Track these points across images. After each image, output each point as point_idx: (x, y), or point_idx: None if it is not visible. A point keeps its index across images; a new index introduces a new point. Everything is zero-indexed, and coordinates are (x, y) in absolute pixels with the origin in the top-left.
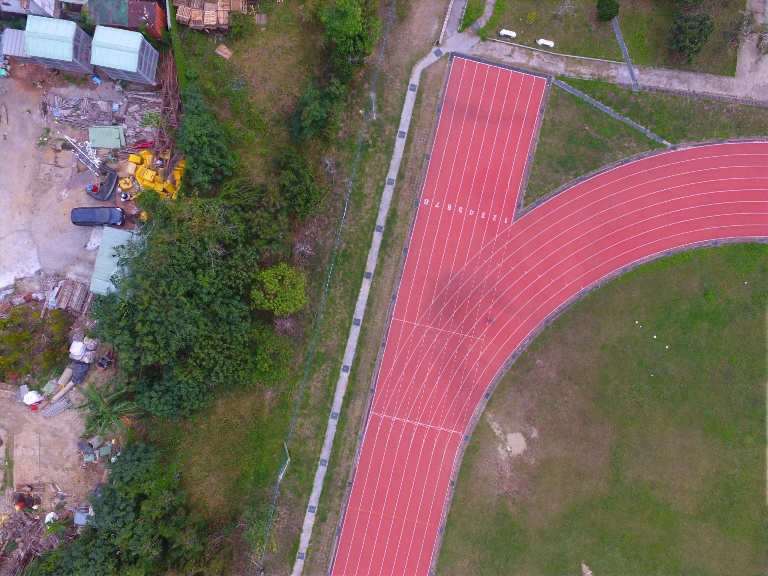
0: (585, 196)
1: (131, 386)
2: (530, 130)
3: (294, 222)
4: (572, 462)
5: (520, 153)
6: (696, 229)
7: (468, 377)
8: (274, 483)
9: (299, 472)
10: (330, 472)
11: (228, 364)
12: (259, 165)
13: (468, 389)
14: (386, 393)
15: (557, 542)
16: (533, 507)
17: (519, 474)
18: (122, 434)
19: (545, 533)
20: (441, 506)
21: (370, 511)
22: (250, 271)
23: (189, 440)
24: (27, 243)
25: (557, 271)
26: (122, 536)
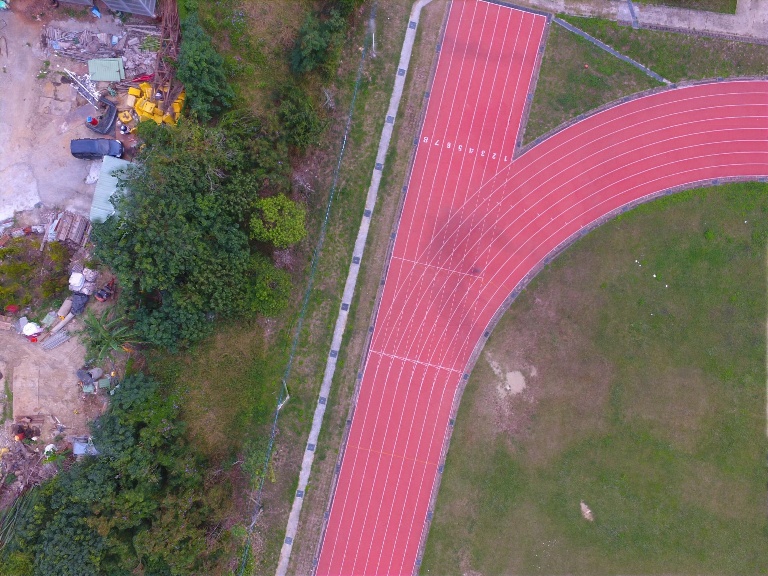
0: (585, 134)
1: (130, 314)
2: (530, 68)
3: (293, 158)
4: (571, 401)
5: (520, 91)
6: (696, 168)
7: (467, 316)
8: (273, 420)
9: (298, 410)
10: (329, 410)
11: (227, 291)
12: (258, 98)
13: (467, 328)
14: (385, 331)
15: (556, 481)
16: (532, 446)
17: (518, 413)
18: (121, 366)
19: (544, 472)
20: (440, 445)
21: (369, 449)
22: (249, 197)
23: (188, 374)
24: (27, 176)
25: (557, 210)
26: (121, 459)
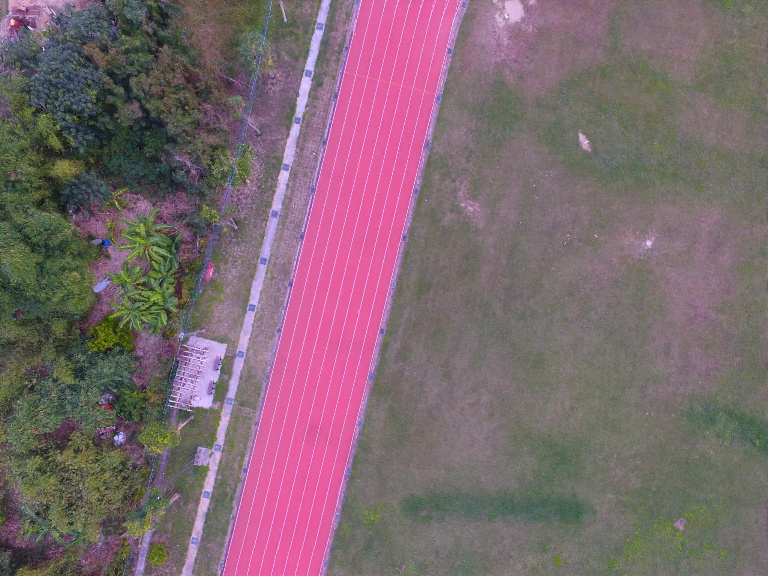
0: None
1: None
2: None
3: None
4: (570, 29)
5: None
6: None
7: None
8: None
9: (295, 33)
10: (327, 36)
11: None
12: None
13: None
14: None
15: (554, 110)
16: (530, 75)
17: (517, 42)
18: None
19: (542, 101)
20: (438, 74)
21: (367, 76)
22: None
23: None
24: None
25: None
26: None
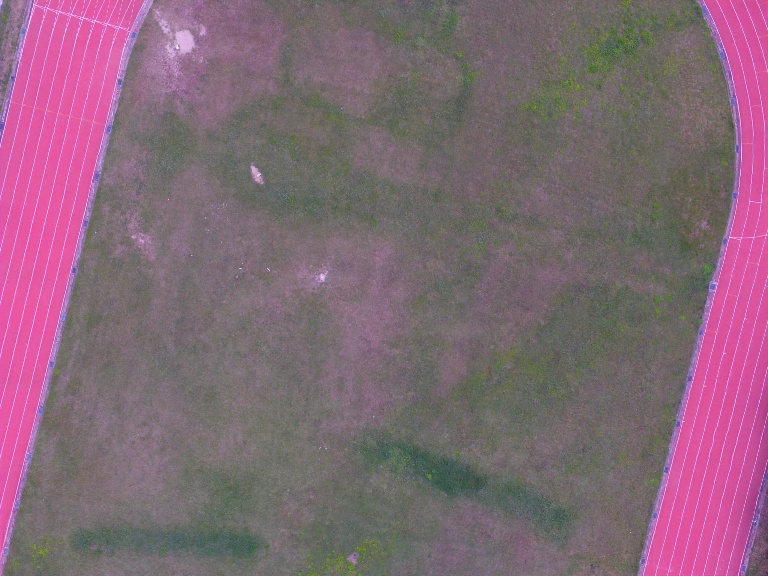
0: None
1: None
2: None
3: None
4: (241, 61)
5: None
6: None
7: None
8: None
9: None
10: None
11: None
12: None
13: None
14: None
15: (225, 142)
16: (201, 107)
17: (187, 73)
18: None
19: (213, 133)
20: (108, 105)
21: (34, 107)
22: None
23: None
24: None
25: None
26: None
